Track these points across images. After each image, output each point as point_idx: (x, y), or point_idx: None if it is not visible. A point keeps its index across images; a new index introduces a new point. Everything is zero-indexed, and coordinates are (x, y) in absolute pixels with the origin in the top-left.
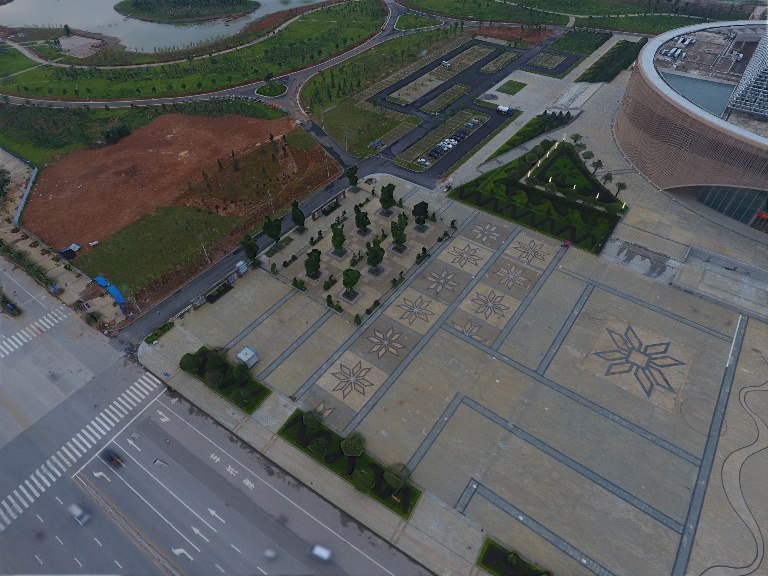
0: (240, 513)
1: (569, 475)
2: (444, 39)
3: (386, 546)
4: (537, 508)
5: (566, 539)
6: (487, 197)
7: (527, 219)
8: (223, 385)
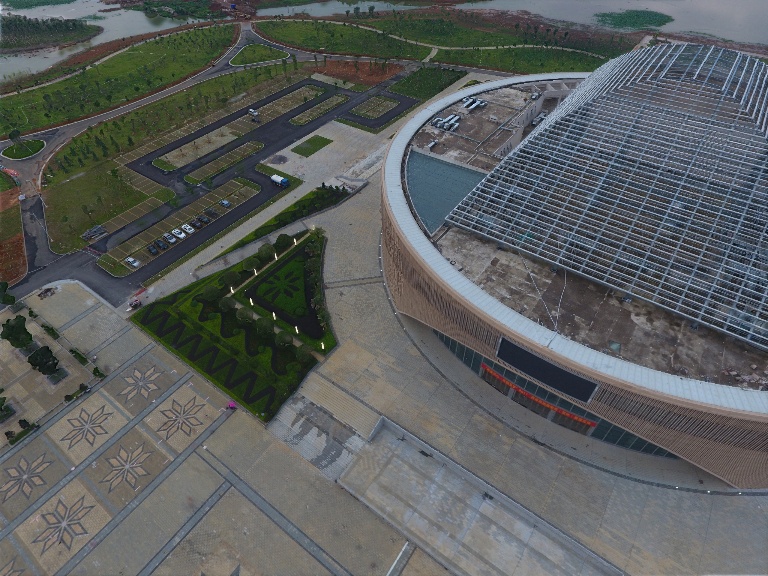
0: None
1: None
2: (268, 79)
3: None
4: None
5: None
6: (173, 323)
7: (205, 360)
8: None
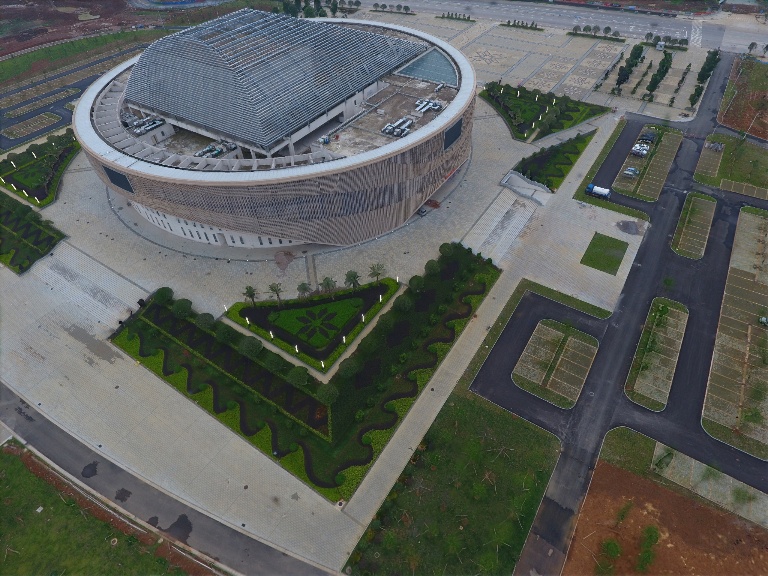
0: None
1: None
2: None
3: None
4: None
5: None
6: (580, 103)
7: None
8: None
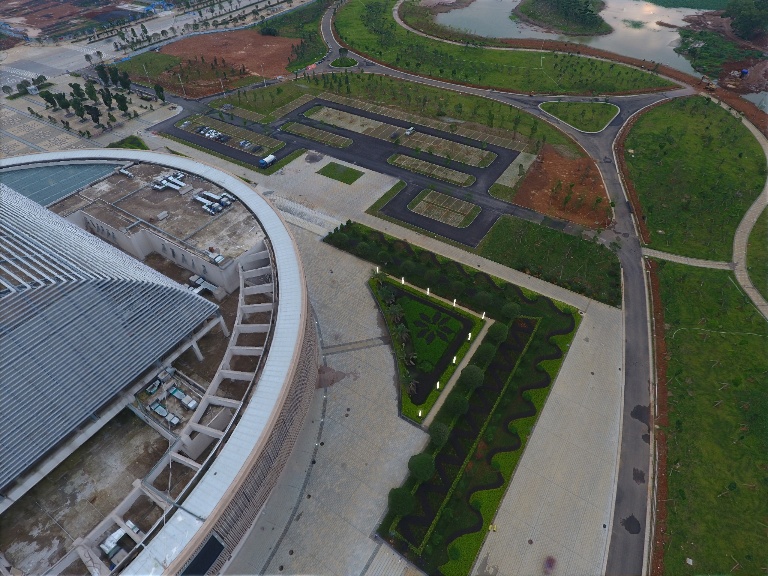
0: None
1: None
2: (488, 125)
3: None
4: None
5: None
6: None
7: None
8: None
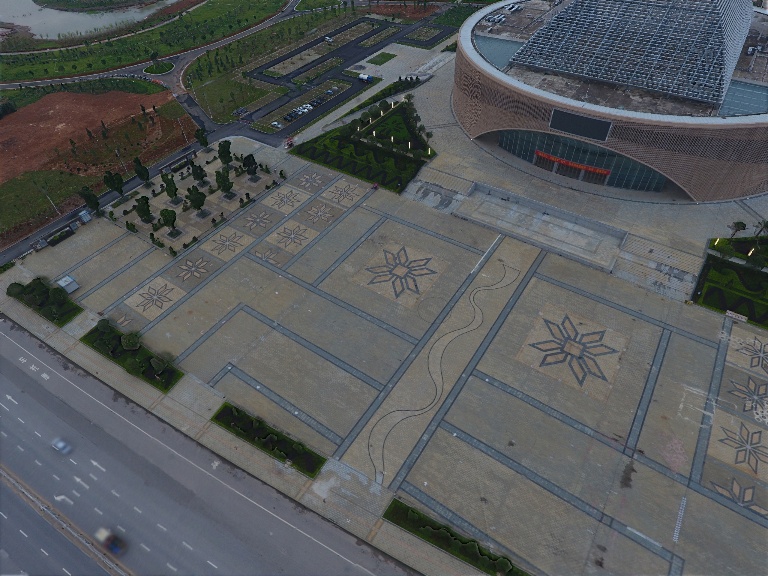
0: (32, 397)
1: (308, 356)
2: (333, 17)
3: (144, 412)
4: (274, 380)
5: (288, 399)
6: (320, 151)
7: (349, 168)
8: (44, 307)
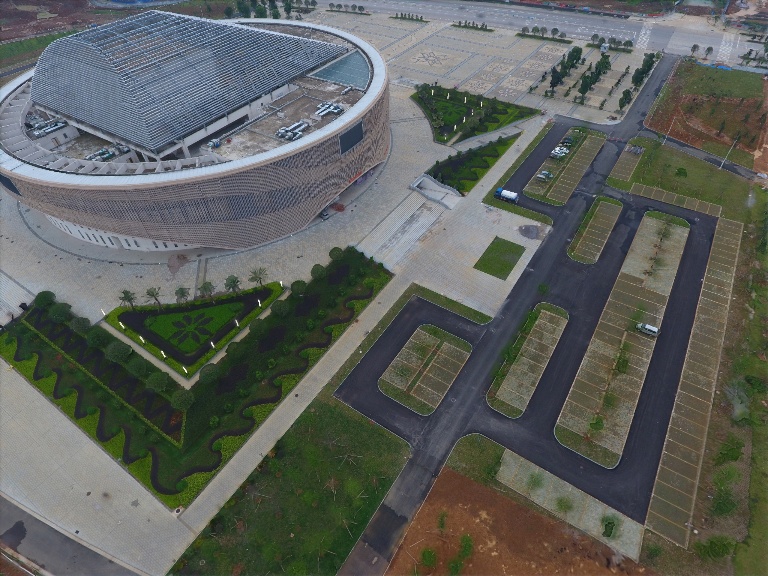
0: None
1: None
2: None
3: None
4: None
5: None
6: (511, 105)
7: None
8: None
